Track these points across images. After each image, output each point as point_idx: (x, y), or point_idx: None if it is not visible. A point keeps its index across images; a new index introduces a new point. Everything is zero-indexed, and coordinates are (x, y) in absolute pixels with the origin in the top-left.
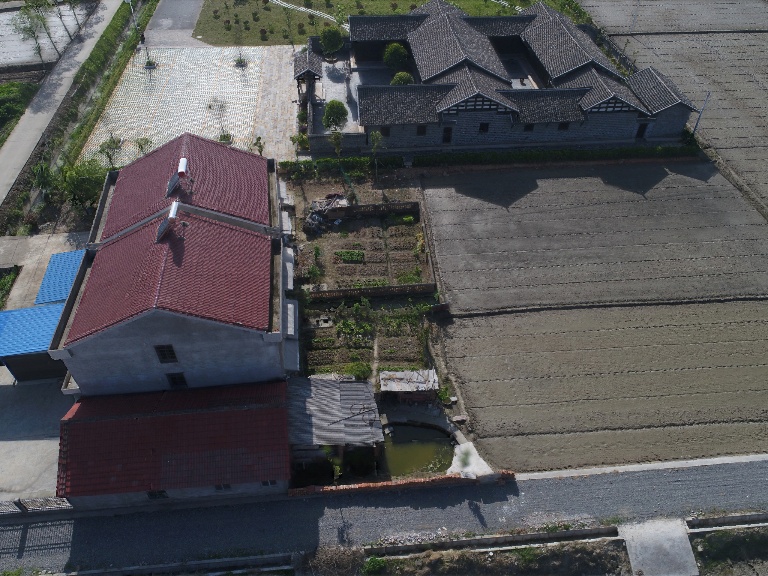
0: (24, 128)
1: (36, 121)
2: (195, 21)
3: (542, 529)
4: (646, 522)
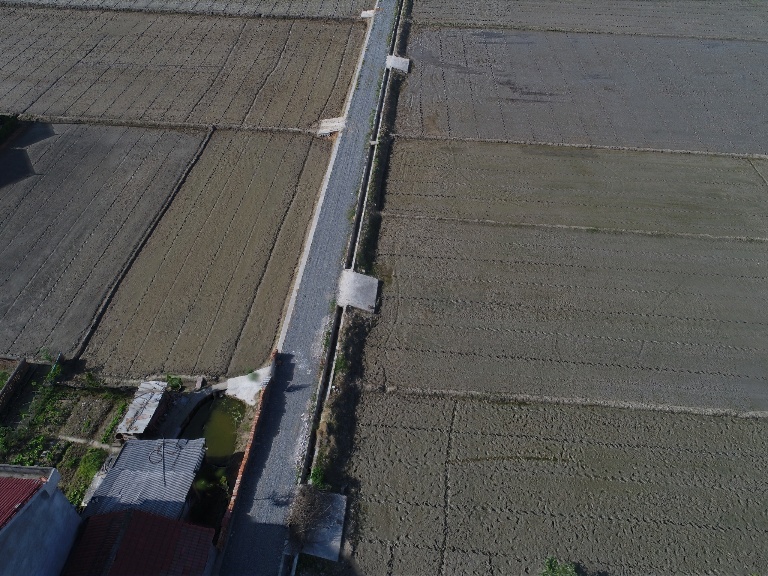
0: None
1: None
2: None
3: (325, 348)
4: (339, 288)
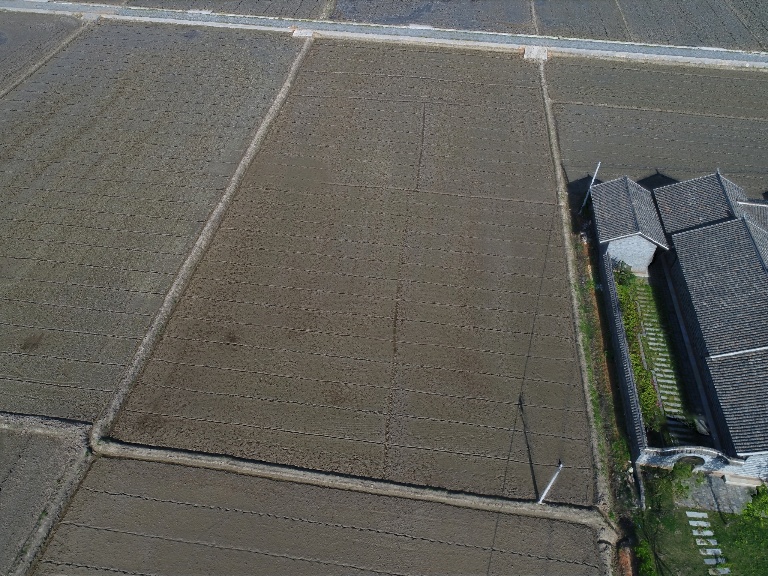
0: None
1: None
2: None
3: None
4: (717, 50)
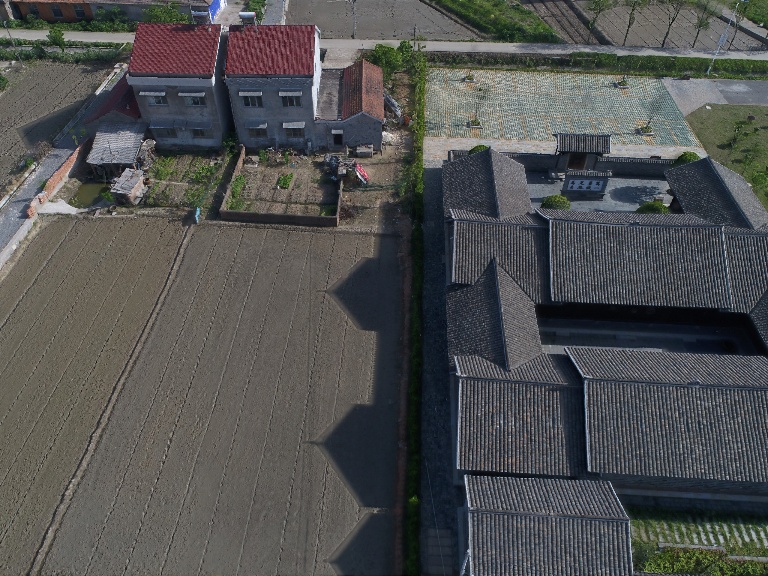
0: (491, 45)
1: (501, 48)
2: (754, 104)
3: None
4: None
